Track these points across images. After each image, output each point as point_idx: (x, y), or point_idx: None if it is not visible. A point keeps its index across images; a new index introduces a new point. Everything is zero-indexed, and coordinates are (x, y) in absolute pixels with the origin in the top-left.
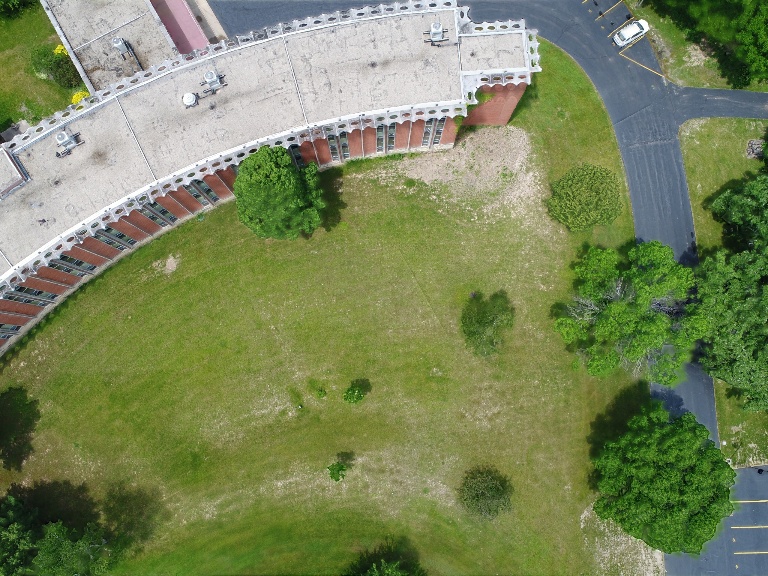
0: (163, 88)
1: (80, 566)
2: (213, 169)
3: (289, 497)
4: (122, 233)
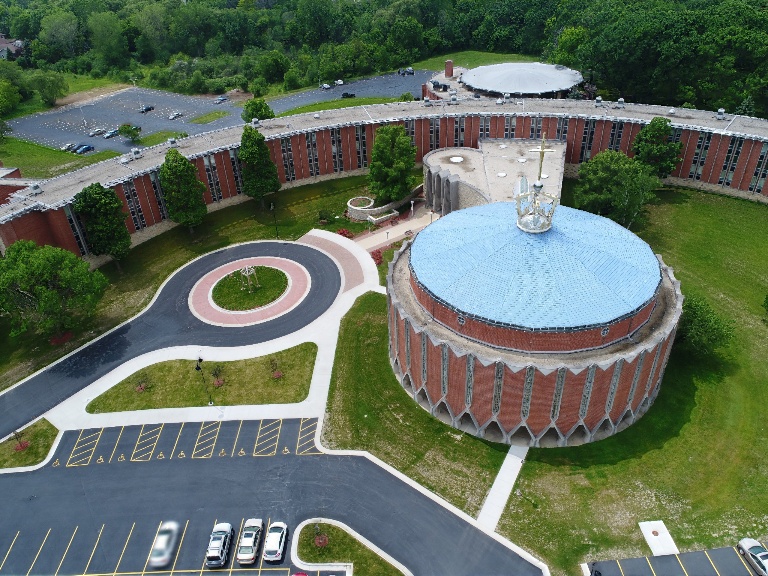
0: None
1: (651, 183)
2: None
3: (716, 301)
4: None
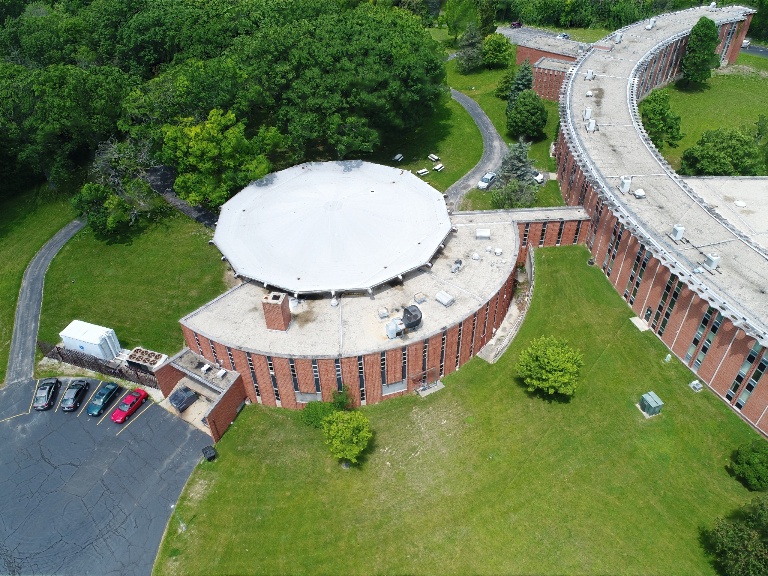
0: (634, 29)
1: None
2: (679, 37)
3: None
4: (645, 79)
